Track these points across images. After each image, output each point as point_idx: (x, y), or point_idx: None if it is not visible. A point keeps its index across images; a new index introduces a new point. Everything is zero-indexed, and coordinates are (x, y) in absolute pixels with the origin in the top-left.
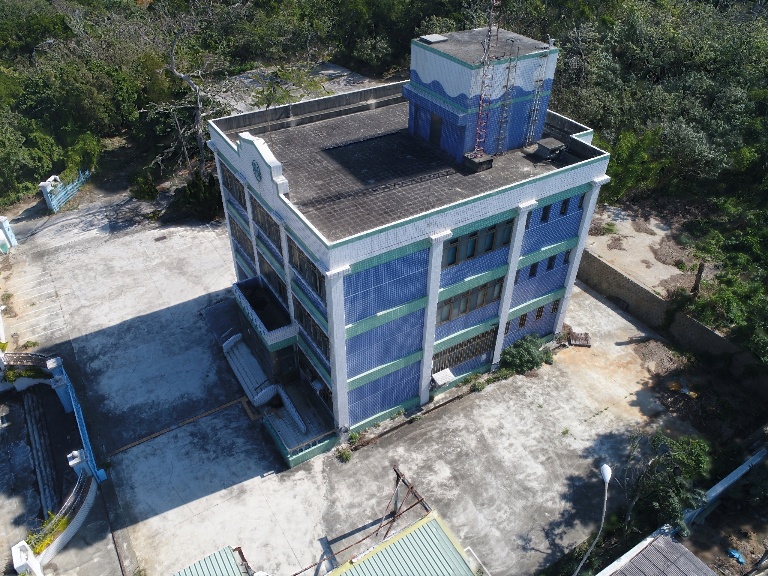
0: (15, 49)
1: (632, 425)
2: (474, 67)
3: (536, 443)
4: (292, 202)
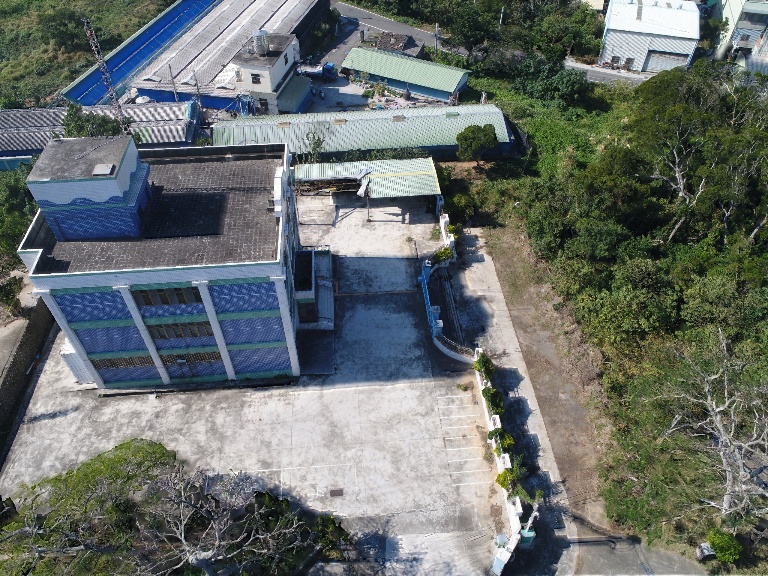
0: None
1: None
2: None
3: None
4: None
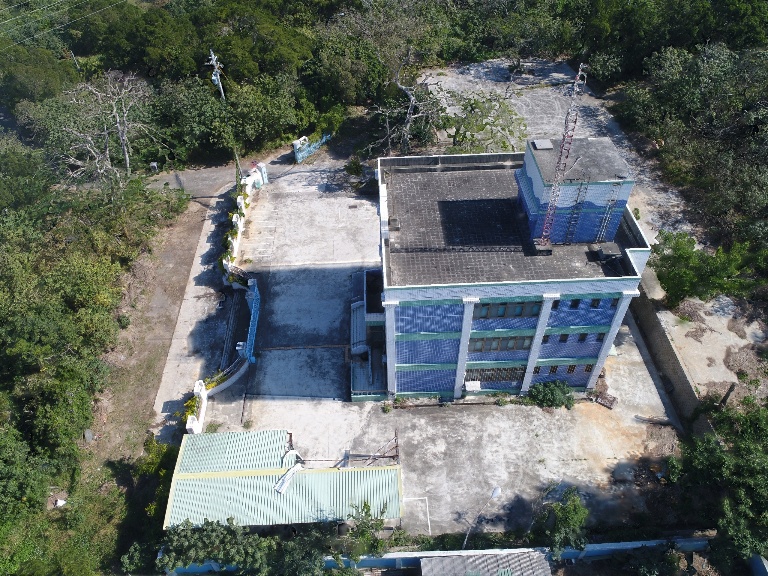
0: (323, 7)
1: (597, 479)
2: (546, 185)
3: (515, 458)
4: (396, 241)
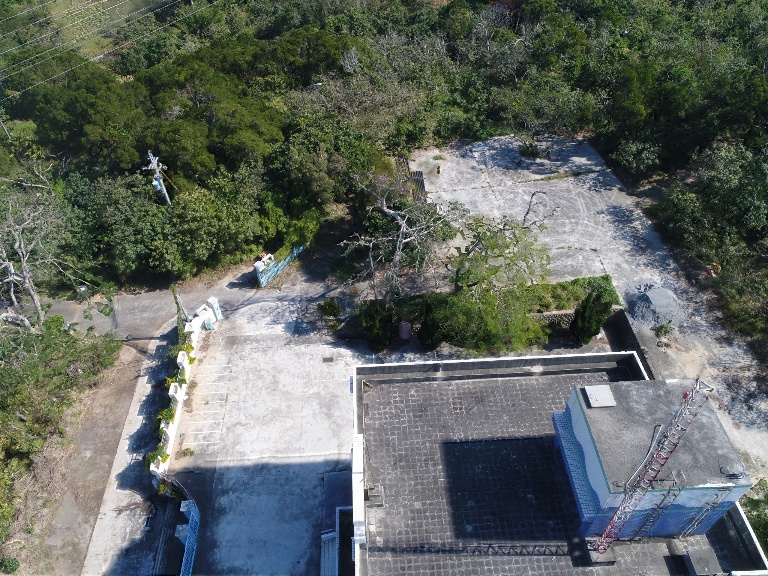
0: (299, 66)
1: None
2: (613, 492)
3: None
4: (377, 530)
